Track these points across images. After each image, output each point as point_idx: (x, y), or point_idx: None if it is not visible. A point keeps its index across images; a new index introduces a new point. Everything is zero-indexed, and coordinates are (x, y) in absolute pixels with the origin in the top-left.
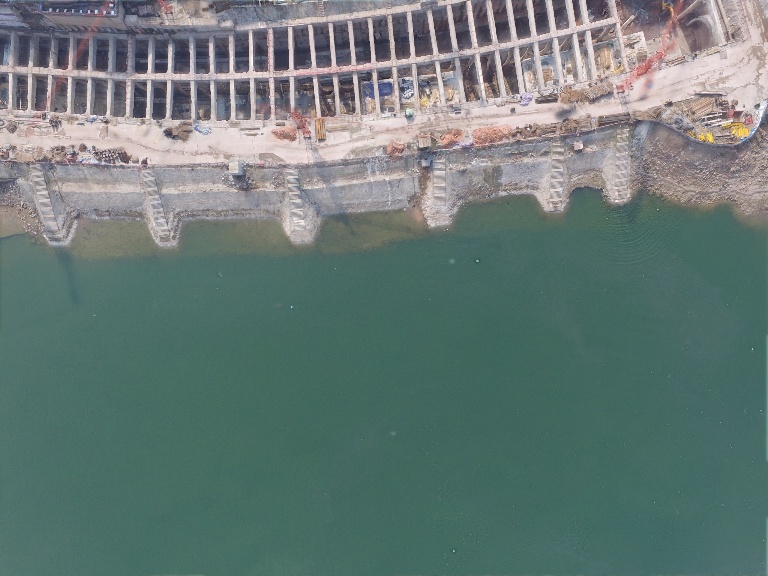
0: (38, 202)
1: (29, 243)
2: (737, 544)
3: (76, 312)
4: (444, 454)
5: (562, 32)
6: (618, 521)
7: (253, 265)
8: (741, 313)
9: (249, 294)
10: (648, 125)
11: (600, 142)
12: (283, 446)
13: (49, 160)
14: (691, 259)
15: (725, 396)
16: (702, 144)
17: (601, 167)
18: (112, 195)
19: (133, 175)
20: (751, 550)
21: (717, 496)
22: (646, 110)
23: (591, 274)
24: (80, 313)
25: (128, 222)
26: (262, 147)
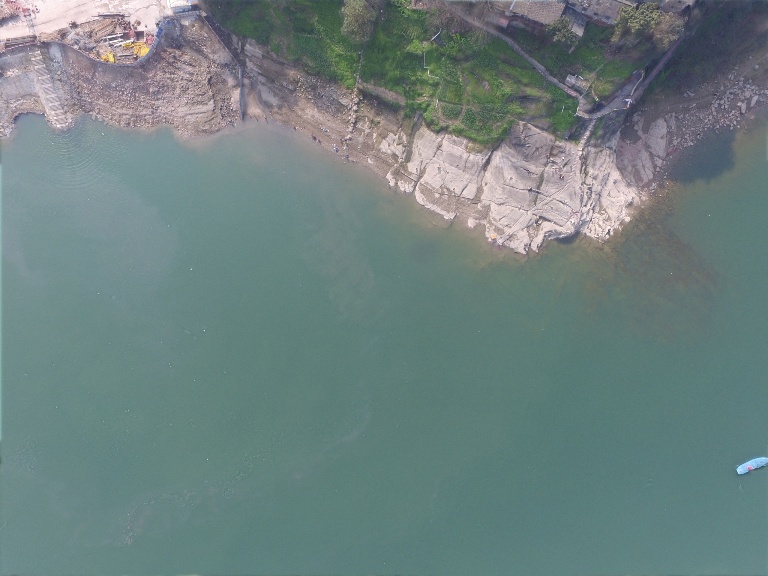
0: None
1: None
2: (182, 463)
3: None
4: None
5: None
6: (65, 440)
7: None
8: (182, 234)
9: None
10: (57, 47)
11: (20, 66)
12: None
13: None
14: (133, 182)
15: (165, 316)
16: (106, 64)
17: (36, 92)
18: None
19: None
20: (195, 468)
21: (164, 415)
22: (52, 32)
23: (41, 198)
24: None
25: None
26: None
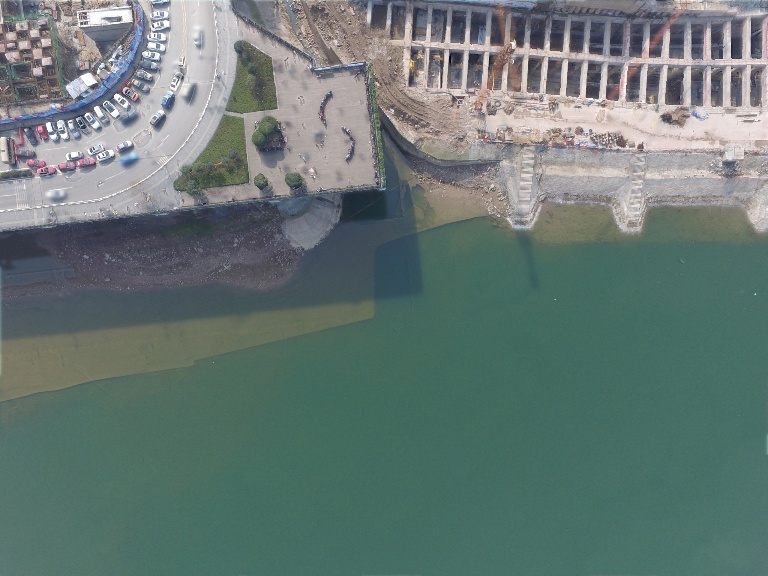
0: (518, 185)
1: (490, 226)
2: None
3: (536, 296)
4: None
5: None
6: None
7: (714, 252)
8: None
9: (711, 281)
10: None
11: None
12: (736, 433)
13: (546, 142)
14: None
15: None
16: None
17: None
18: (594, 179)
19: (623, 159)
20: None
21: None
22: None
23: None
24: (540, 297)
25: (591, 207)
26: (758, 134)
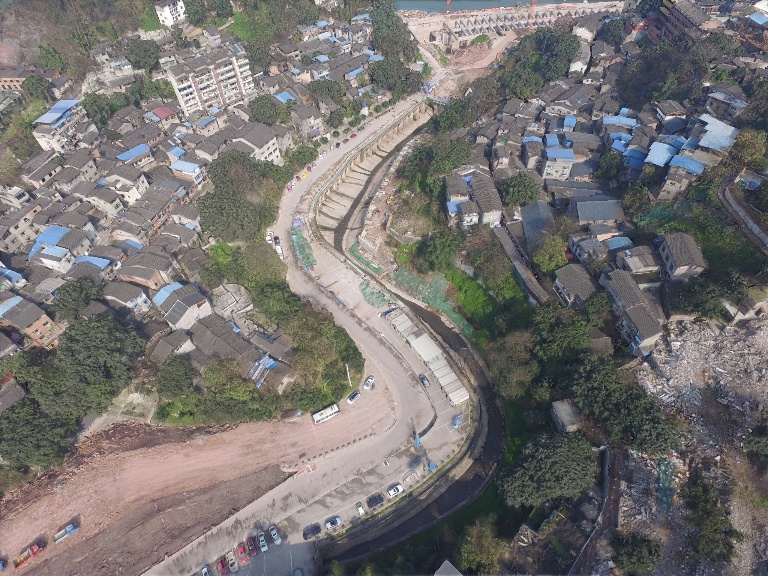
0: None
1: None
2: None
3: None
4: None
5: (472, 26)
6: None
7: (570, 2)
8: None
9: None
10: None
11: None
12: None
13: None
14: None
15: None
16: None
17: None
18: None
19: None
20: None
21: None
22: None
23: (445, 6)
24: None
25: None
26: (578, 5)
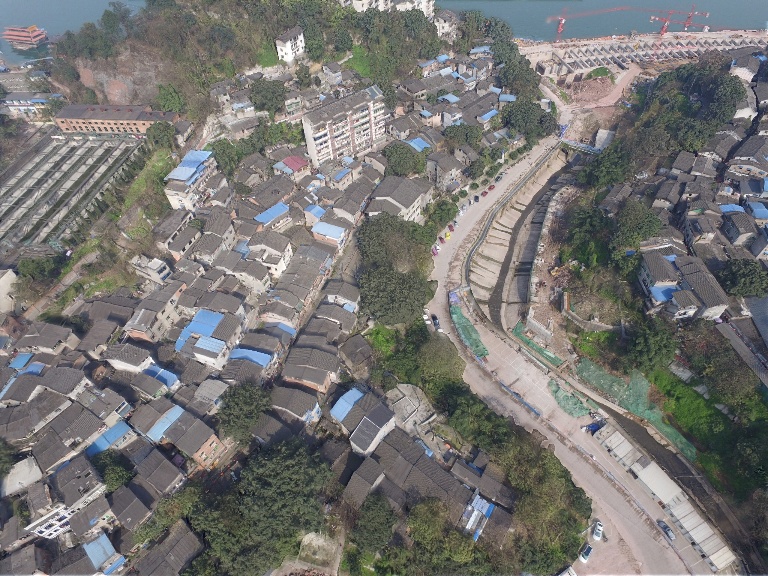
0: None
1: None
2: None
3: None
4: (585, 5)
5: (586, 57)
6: None
7: None
8: None
9: None
10: None
11: None
12: None
13: None
14: None
15: None
16: None
17: None
18: None
19: None
20: None
21: (485, 3)
22: None
23: None
24: None
25: None
26: None
